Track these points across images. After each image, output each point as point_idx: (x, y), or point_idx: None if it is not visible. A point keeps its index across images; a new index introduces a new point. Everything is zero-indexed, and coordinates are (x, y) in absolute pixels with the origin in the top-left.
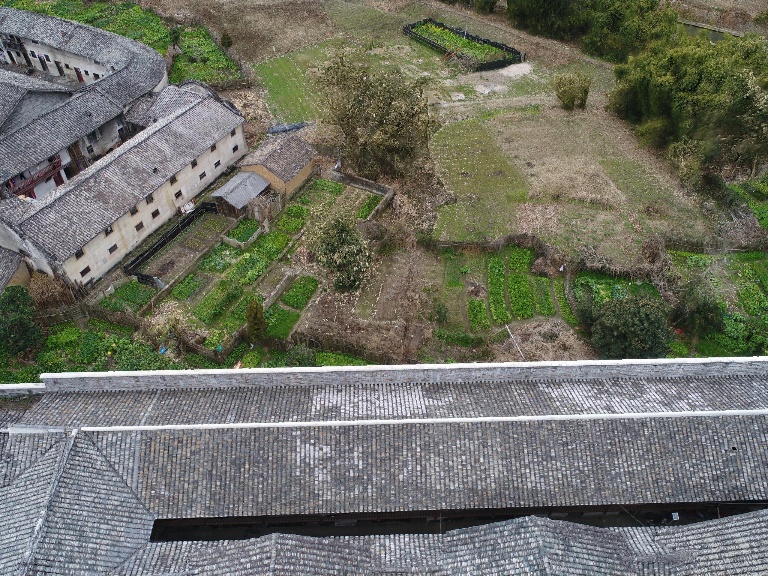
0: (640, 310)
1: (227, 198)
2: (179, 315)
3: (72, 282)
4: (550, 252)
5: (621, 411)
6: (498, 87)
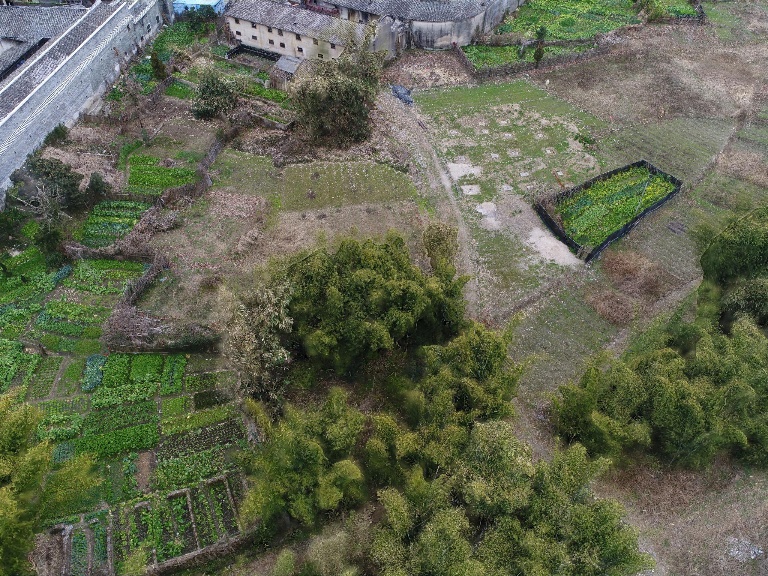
0: (38, 158)
1: (281, 58)
2: (202, 65)
3: (232, 31)
4: None
5: None
6: (493, 221)
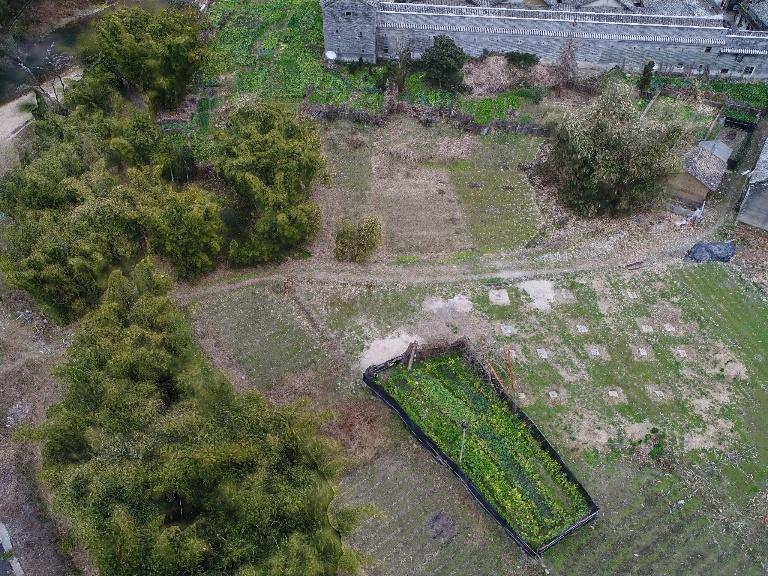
0: None
1: None
2: (699, 110)
3: None
4: (462, 112)
5: (482, 11)
6: (437, 306)
